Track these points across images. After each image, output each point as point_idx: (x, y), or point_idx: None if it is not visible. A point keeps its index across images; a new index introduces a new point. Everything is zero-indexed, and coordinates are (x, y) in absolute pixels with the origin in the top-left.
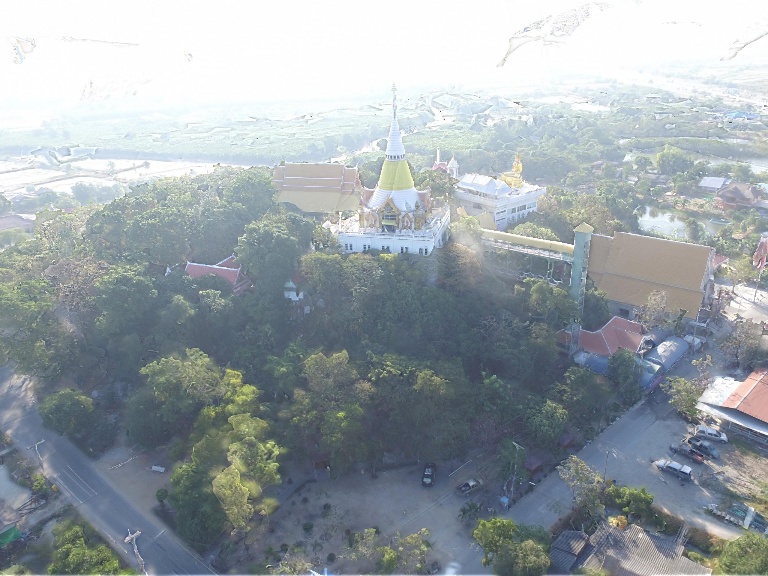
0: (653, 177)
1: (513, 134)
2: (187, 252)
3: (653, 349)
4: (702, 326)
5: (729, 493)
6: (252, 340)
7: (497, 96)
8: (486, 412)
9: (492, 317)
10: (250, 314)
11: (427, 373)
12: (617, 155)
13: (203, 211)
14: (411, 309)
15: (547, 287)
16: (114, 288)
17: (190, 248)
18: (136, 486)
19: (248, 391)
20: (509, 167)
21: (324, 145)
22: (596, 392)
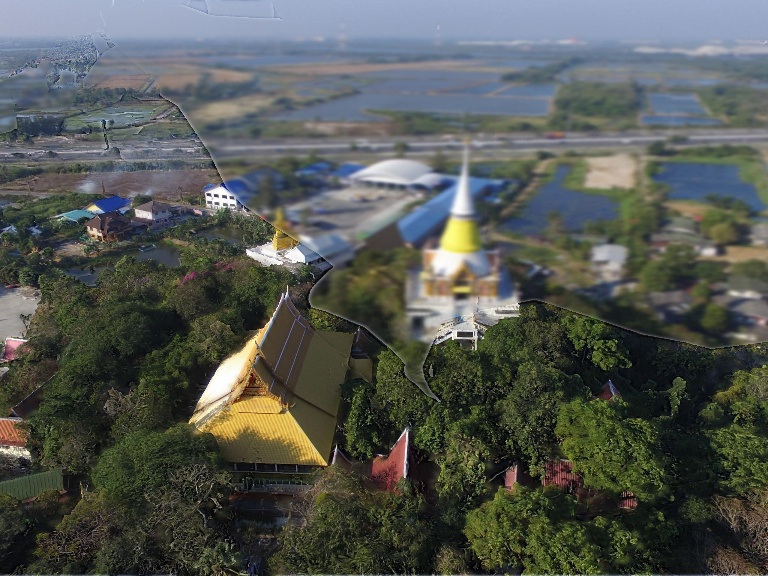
0: None
1: None
2: None
3: None
4: None
5: None
6: None
7: None
8: None
9: None
10: None
11: None
12: None
13: None
14: None
15: None
16: None
17: None
18: None
19: (743, 375)
20: None
21: None
22: None
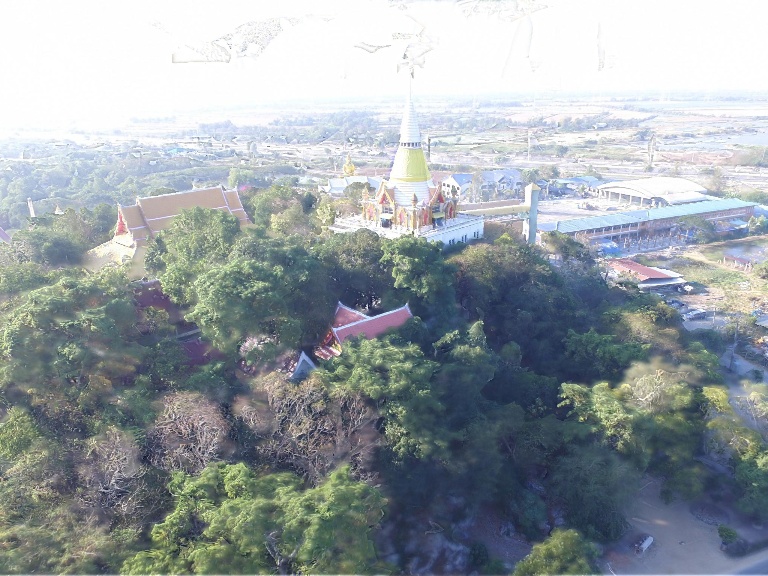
0: None
1: None
2: None
3: None
4: None
5: (718, 313)
6: None
7: None
8: None
9: None
10: None
11: None
12: (186, 185)
13: (273, 255)
14: None
15: None
16: (425, 372)
17: None
18: (680, 571)
19: None
20: None
21: None
22: None
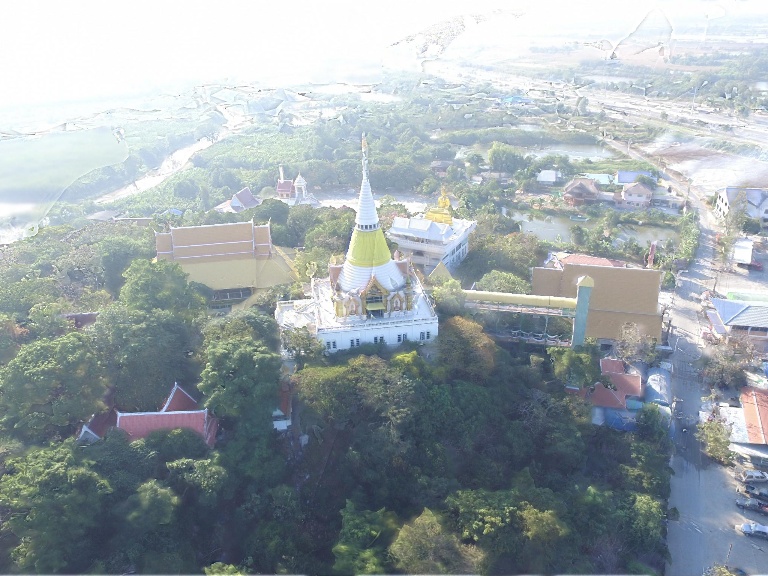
0: (496, 176)
1: (332, 136)
2: (103, 394)
3: (647, 387)
4: (669, 350)
5: None
6: (261, 510)
7: (281, 89)
8: (599, 536)
9: (529, 403)
10: (247, 474)
11: (534, 512)
12: (449, 154)
13: (116, 332)
14: (454, 419)
15: (574, 356)
16: (43, 501)
17: (106, 388)
18: None
19: None
20: (357, 178)
21: (122, 166)
22: (654, 463)
